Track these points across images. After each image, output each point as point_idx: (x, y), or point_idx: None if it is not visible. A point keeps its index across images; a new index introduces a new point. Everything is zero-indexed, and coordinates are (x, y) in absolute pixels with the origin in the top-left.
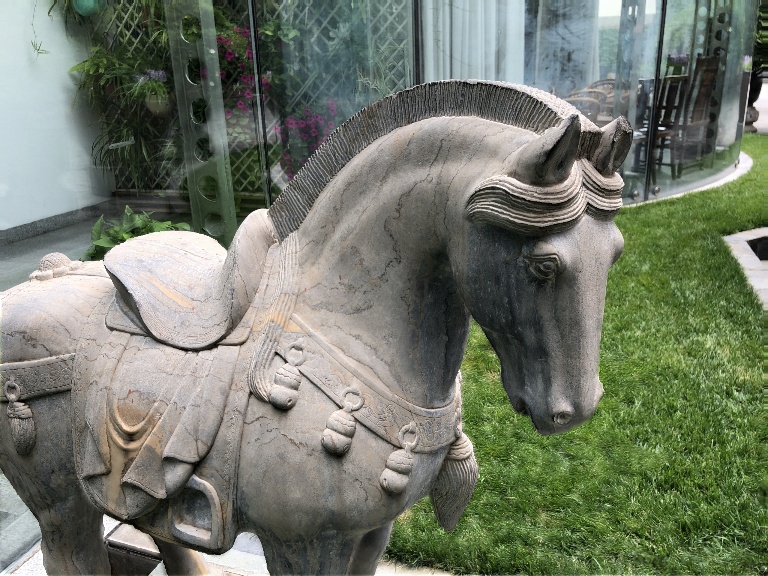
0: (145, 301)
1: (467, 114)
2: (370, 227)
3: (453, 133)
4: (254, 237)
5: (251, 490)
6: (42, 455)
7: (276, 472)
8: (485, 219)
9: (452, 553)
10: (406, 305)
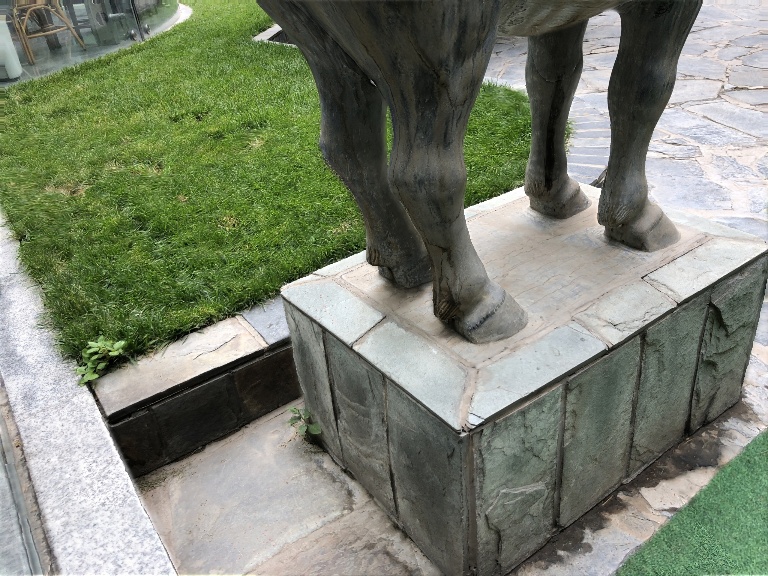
0: None
1: None
2: None
3: None
4: None
5: None
6: None
7: None
8: None
9: None
10: None
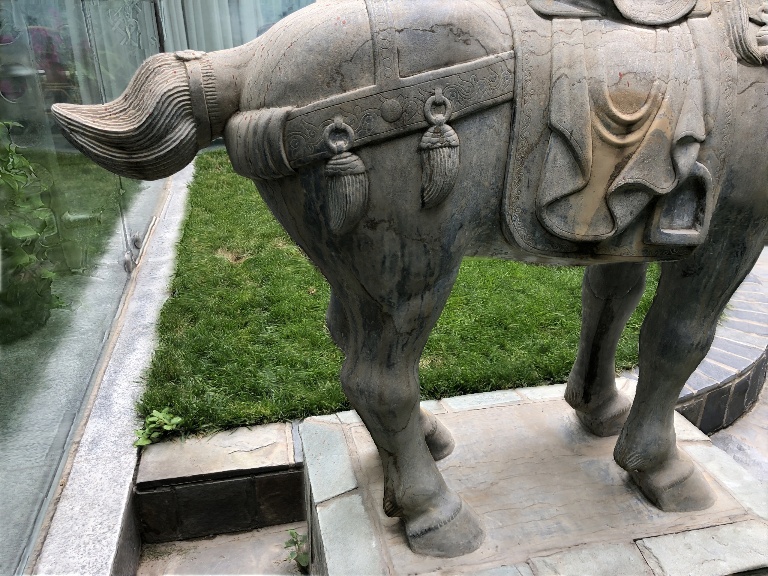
0: None
1: None
2: None
3: None
4: None
5: (745, 165)
6: (457, 203)
7: None
8: None
9: (514, 372)
10: None
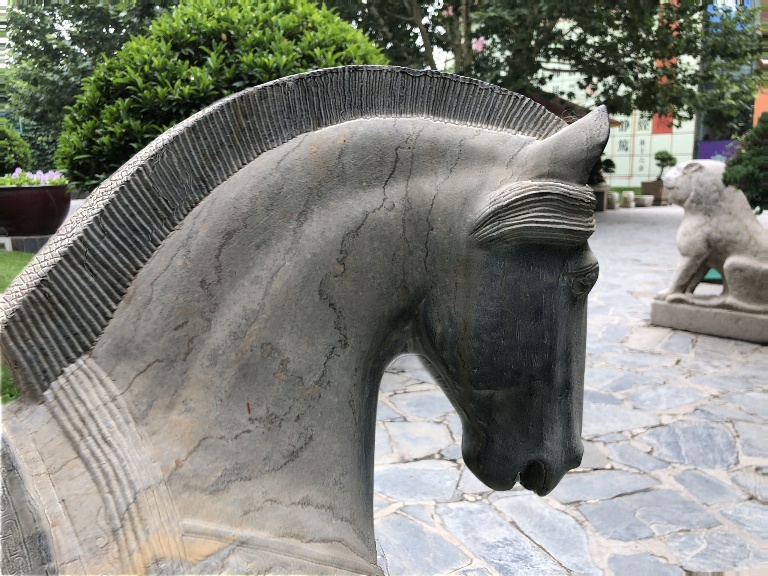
0: None
1: (411, 115)
2: (293, 300)
3: (413, 138)
4: None
5: None
6: None
7: None
8: (517, 239)
9: None
10: (352, 413)
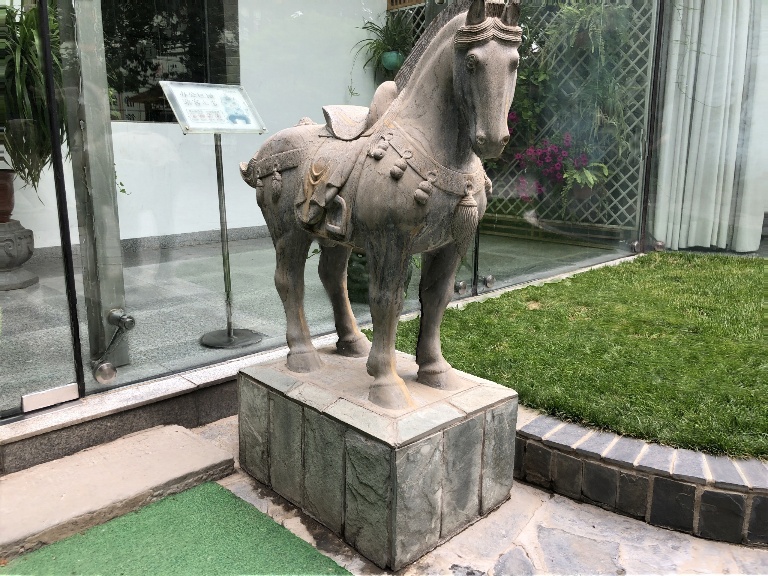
0: (335, 120)
1: None
2: (429, 73)
3: None
4: (387, 91)
5: (360, 201)
6: (282, 202)
7: (370, 189)
8: None
9: (530, 395)
10: (440, 110)
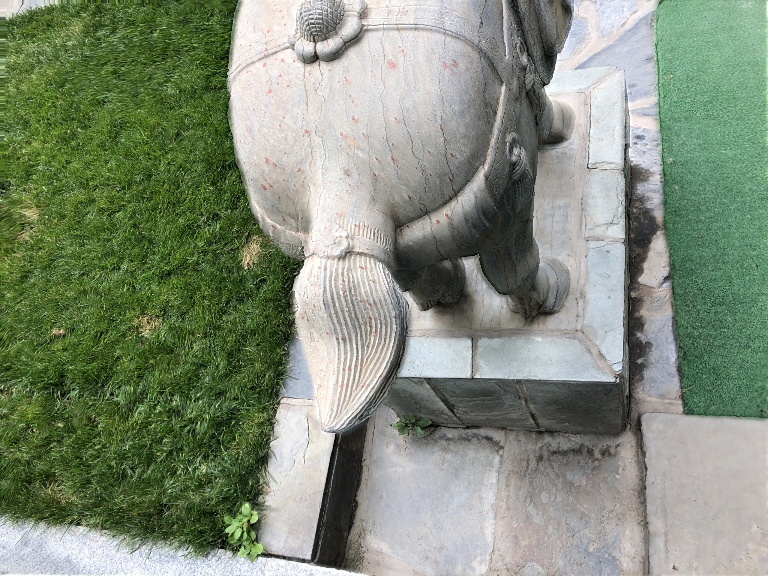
0: None
1: None
2: None
3: None
4: None
5: None
6: None
7: None
8: None
9: None
10: None
